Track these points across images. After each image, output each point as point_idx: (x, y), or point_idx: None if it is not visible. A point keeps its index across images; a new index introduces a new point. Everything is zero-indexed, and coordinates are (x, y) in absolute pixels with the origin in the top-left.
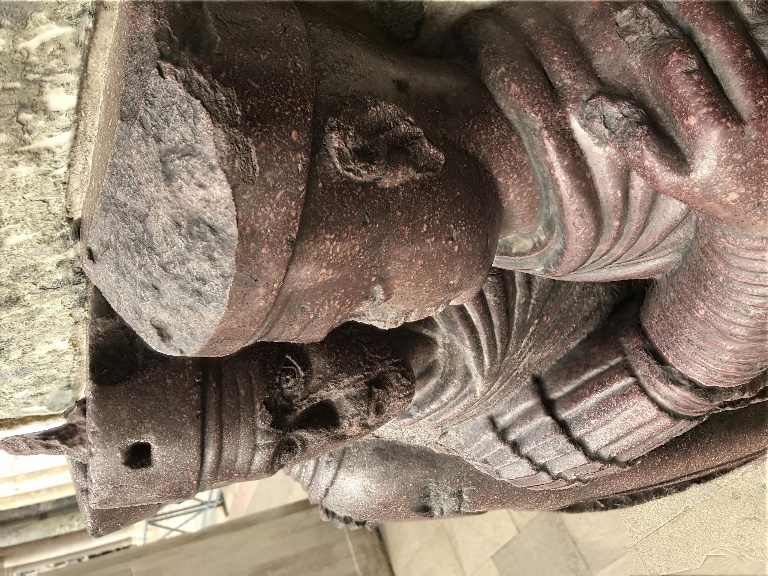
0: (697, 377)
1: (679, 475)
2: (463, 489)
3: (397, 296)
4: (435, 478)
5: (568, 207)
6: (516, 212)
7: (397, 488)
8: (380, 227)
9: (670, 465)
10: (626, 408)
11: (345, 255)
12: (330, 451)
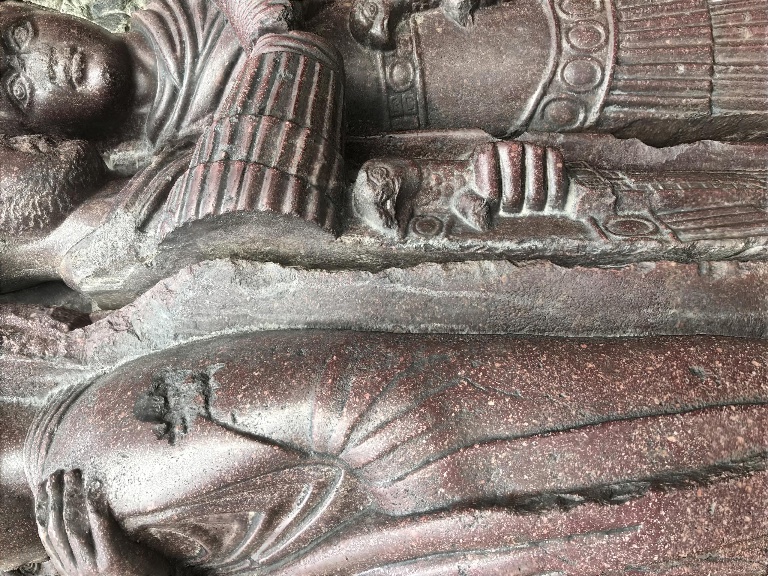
0: (251, 28)
1: (700, 399)
2: (211, 376)
3: (41, 33)
4: (173, 365)
5: (141, 17)
6: (134, 45)
7: (123, 384)
8: (33, 8)
9: (622, 356)
10: (234, 83)
11: (11, 5)
12: (6, 168)
